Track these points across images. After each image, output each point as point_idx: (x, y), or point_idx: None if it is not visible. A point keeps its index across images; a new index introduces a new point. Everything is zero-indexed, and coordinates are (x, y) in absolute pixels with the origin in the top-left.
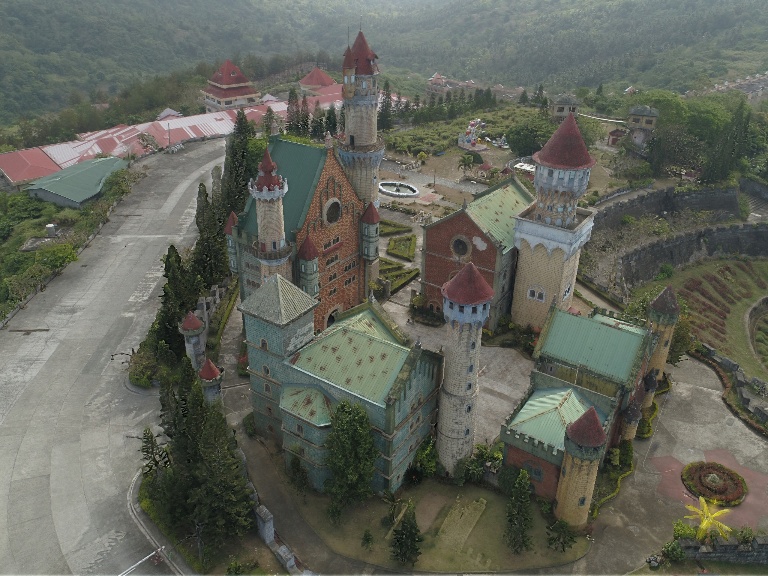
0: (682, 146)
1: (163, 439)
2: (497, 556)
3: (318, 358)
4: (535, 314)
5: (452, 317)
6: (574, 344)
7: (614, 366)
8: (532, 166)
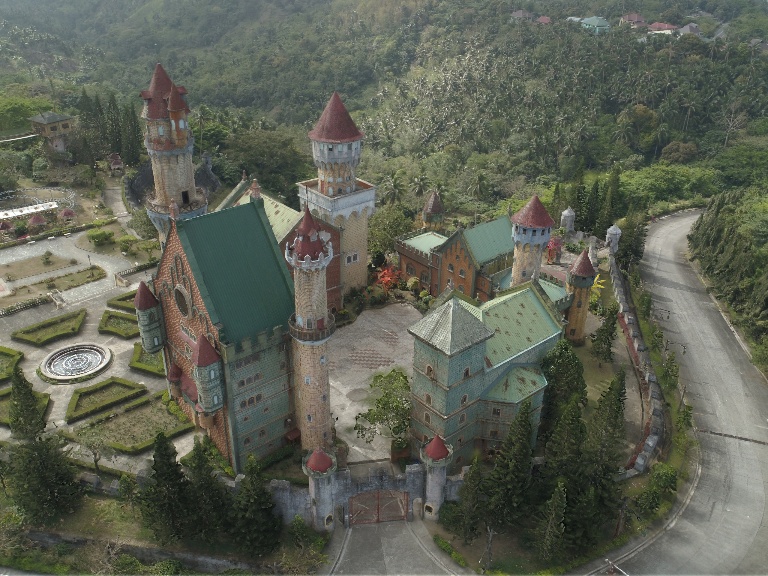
0: (89, 141)
1: (427, 568)
2: (603, 376)
3: (498, 346)
4: (353, 276)
5: (544, 241)
6: (486, 246)
7: (510, 243)
8: (17, 210)
